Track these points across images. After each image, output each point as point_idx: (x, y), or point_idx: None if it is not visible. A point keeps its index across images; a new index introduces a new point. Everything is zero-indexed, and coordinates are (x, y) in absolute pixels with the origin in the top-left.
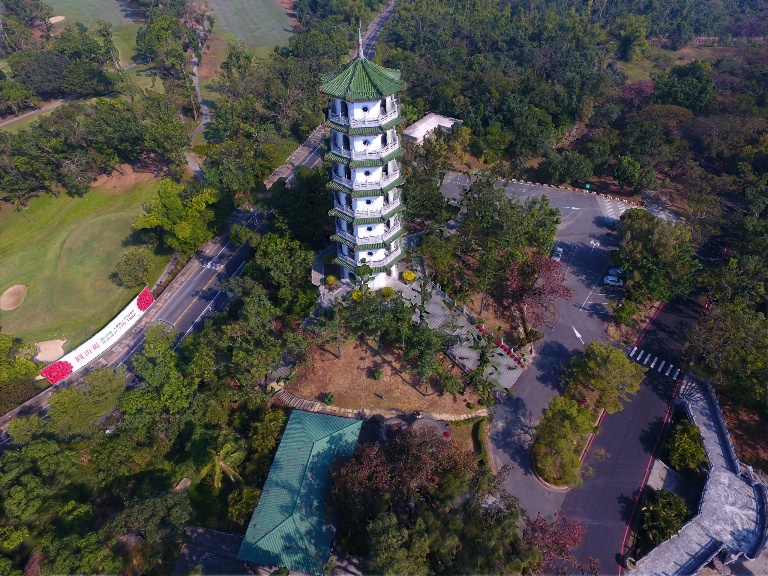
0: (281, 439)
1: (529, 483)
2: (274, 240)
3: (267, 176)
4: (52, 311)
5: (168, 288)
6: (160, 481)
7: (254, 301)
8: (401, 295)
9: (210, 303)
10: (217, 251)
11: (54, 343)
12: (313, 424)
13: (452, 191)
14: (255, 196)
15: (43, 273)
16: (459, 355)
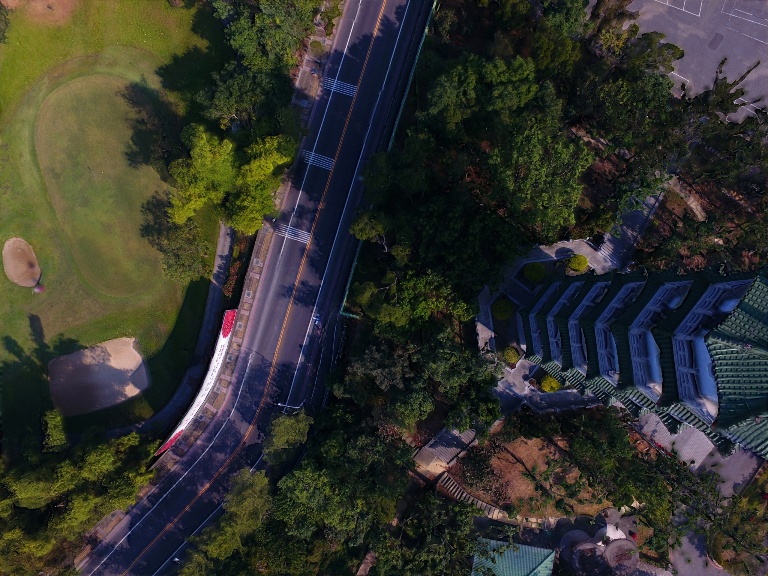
0: (471, 574)
1: (702, 565)
2: (424, 297)
3: (336, 7)
4: (92, 296)
5: (246, 284)
6: (339, 568)
7: (415, 414)
8: (635, 447)
9: (313, 311)
10: (292, 200)
11: (121, 342)
12: (504, 561)
13: (671, 38)
14: (385, 220)
15: (39, 222)
16: (661, 438)
